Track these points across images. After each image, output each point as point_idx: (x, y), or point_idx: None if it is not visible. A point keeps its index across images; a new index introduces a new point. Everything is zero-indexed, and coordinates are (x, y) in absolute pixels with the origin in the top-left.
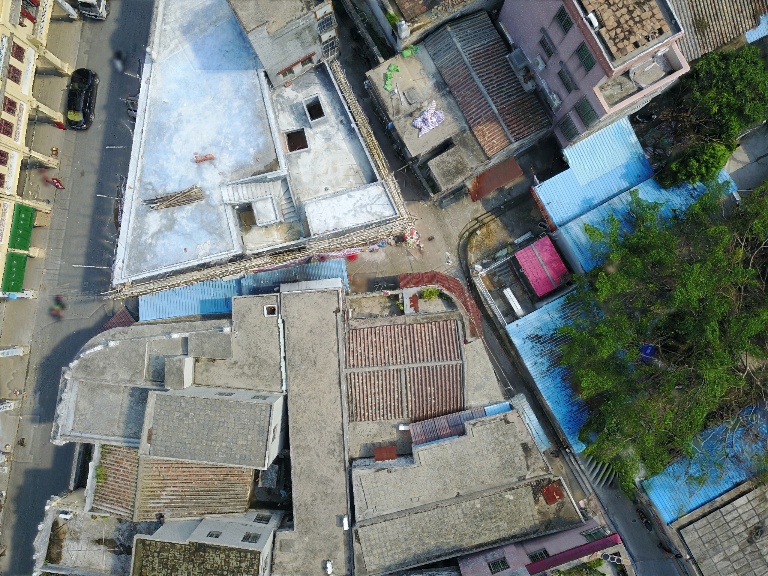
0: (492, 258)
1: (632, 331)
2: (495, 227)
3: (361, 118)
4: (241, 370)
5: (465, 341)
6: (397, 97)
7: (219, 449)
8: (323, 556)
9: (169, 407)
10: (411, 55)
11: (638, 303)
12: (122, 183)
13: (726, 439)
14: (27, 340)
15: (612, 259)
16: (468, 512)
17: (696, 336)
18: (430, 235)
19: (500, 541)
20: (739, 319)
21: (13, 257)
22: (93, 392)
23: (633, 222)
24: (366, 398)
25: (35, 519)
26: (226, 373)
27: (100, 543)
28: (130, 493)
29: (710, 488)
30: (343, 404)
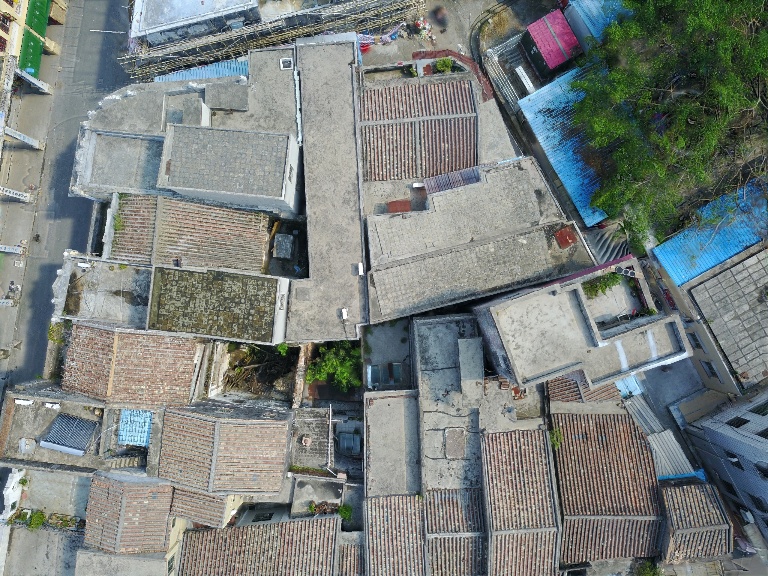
0: None
1: (644, 74)
2: (507, 16)
3: None
4: (257, 123)
5: None
6: None
7: (237, 180)
8: (338, 304)
9: (187, 139)
10: None
11: (651, 42)
12: None
13: (737, 190)
14: (42, 136)
15: (625, 7)
16: (482, 256)
17: (708, 67)
18: (442, 28)
19: (513, 285)
20: None
21: (30, 37)
22: (111, 146)
23: None
24: (380, 155)
25: (50, 314)
26: (242, 126)
27: (117, 294)
28: (148, 239)
29: (720, 252)
30: (358, 154)
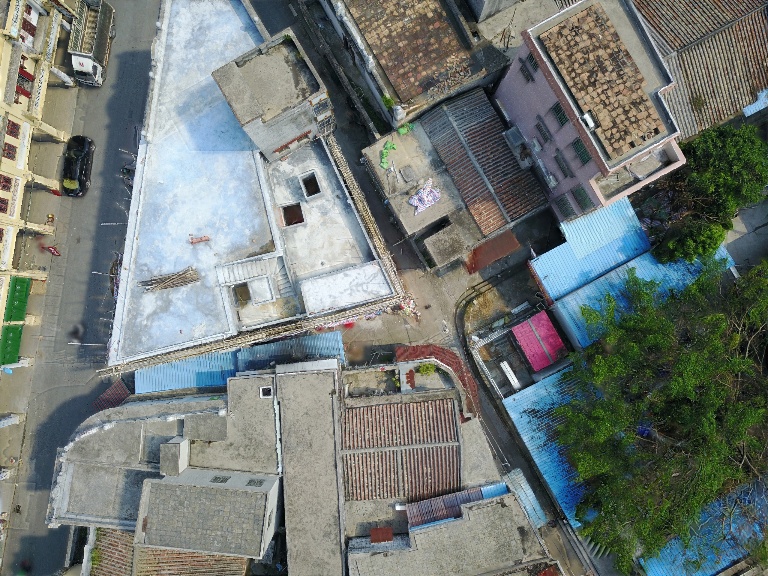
0: (489, 328)
1: (629, 416)
2: (492, 297)
3: (357, 192)
4: (237, 452)
5: (462, 417)
6: (393, 175)
7: (214, 538)
8: None
9: (164, 495)
10: (407, 133)
11: (635, 389)
12: (118, 260)
13: (723, 521)
14: (23, 407)
15: (609, 342)
16: None
17: (693, 425)
18: (427, 303)
19: None
20: (736, 407)
21: (9, 330)
22: (88, 473)
23: (630, 297)
24: (362, 478)
25: None
26: (222, 455)
27: None
28: None
29: (707, 566)
30: (339, 487)
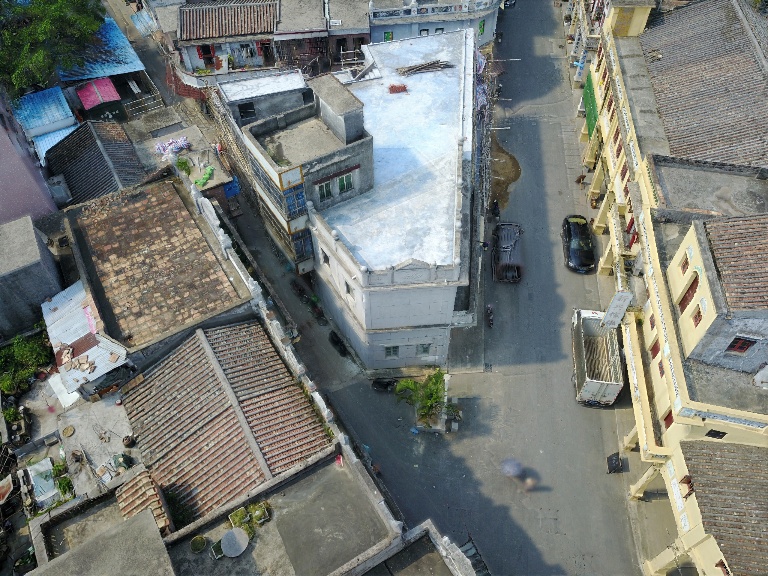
0: None
1: (32, 8)
2: None
3: None
4: None
5: None
6: None
7: None
8: None
9: None
10: None
11: (19, 10)
12: None
13: None
14: (576, 92)
15: None
16: None
17: None
18: None
19: None
20: None
21: None
22: None
23: None
24: None
25: (538, 17)
26: None
27: None
28: None
29: None
30: None
